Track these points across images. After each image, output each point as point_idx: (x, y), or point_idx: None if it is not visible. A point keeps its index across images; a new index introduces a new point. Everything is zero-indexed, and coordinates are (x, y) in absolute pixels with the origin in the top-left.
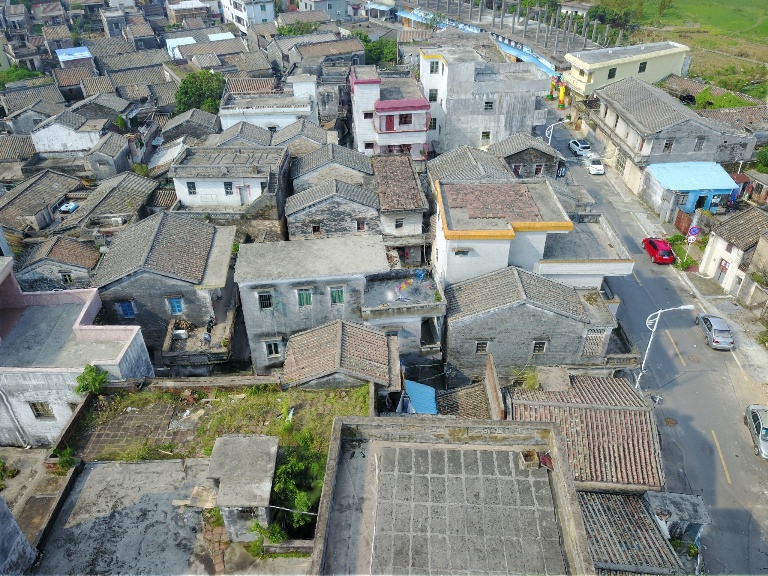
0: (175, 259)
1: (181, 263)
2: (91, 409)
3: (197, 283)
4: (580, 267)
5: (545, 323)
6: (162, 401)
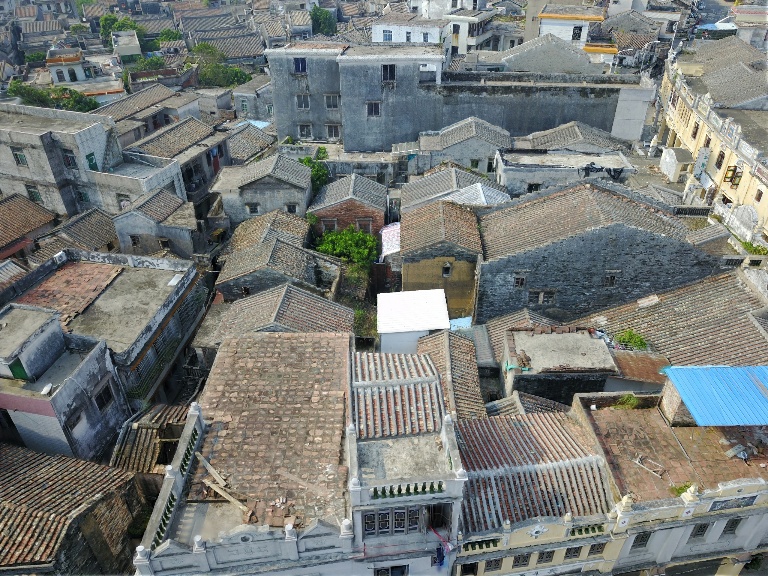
0: (517, 1)
1: (518, 2)
2: (492, 17)
3: (523, 7)
4: (659, 15)
5: (636, 24)
6: (511, 19)
